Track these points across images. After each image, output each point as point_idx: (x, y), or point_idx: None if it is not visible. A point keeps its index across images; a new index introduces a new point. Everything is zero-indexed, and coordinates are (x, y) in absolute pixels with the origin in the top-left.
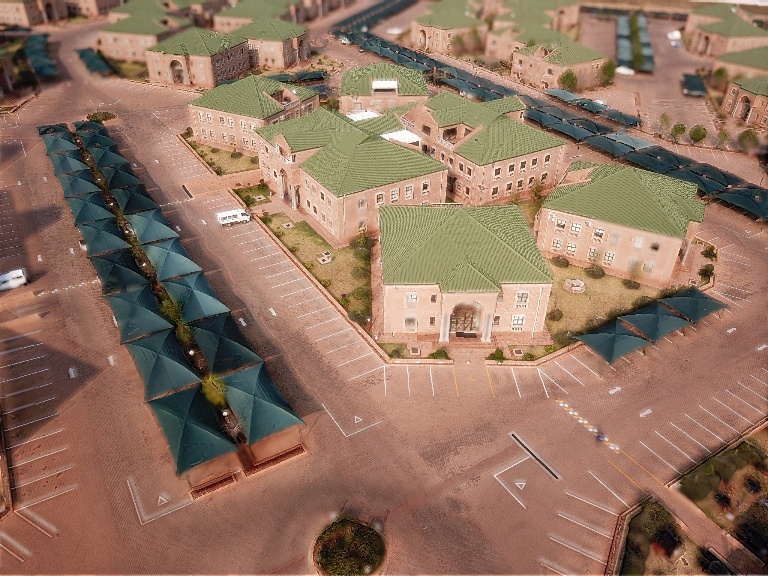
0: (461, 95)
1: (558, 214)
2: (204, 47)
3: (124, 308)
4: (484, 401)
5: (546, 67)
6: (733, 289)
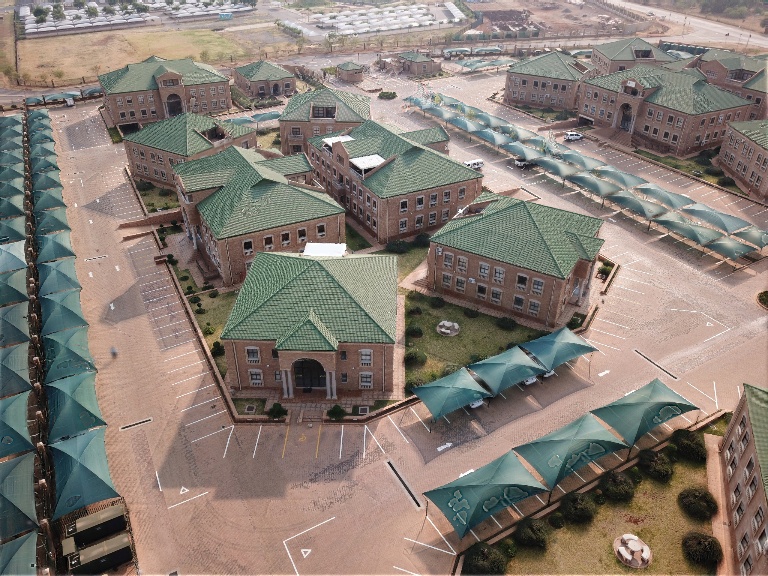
0: None
1: None
2: None
3: None
4: None
5: None
6: None
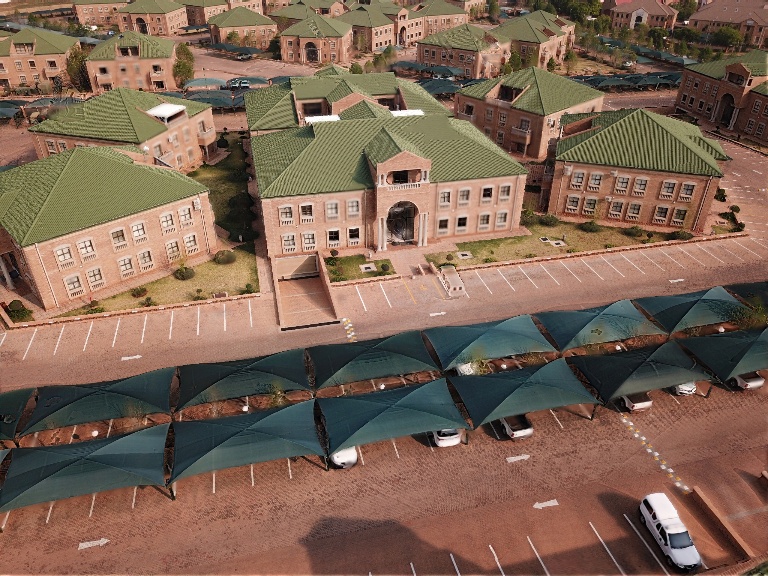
0: None
1: None
2: None
3: (766, 350)
4: None
5: (149, 65)
6: None
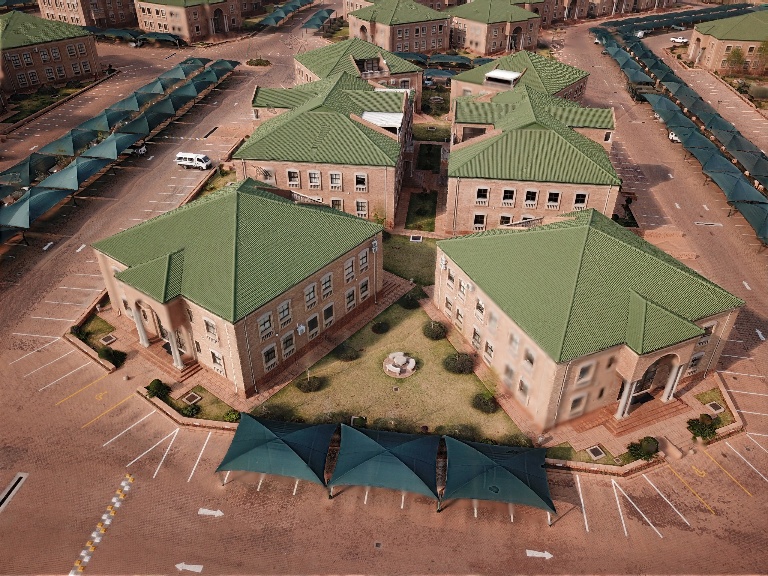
0: (654, 116)
1: (449, 260)
2: (391, 16)
3: None
4: (65, 425)
5: None
6: (660, 500)
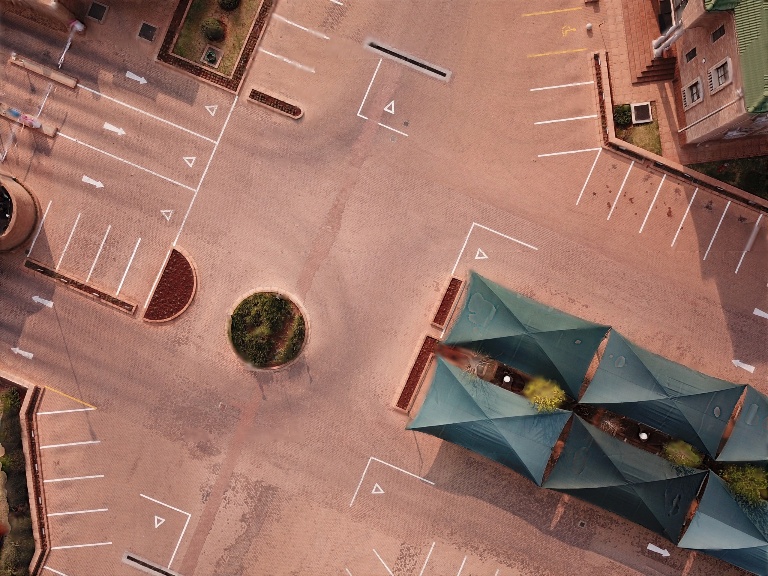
0: None
1: None
2: None
3: None
4: None
5: None
6: None
